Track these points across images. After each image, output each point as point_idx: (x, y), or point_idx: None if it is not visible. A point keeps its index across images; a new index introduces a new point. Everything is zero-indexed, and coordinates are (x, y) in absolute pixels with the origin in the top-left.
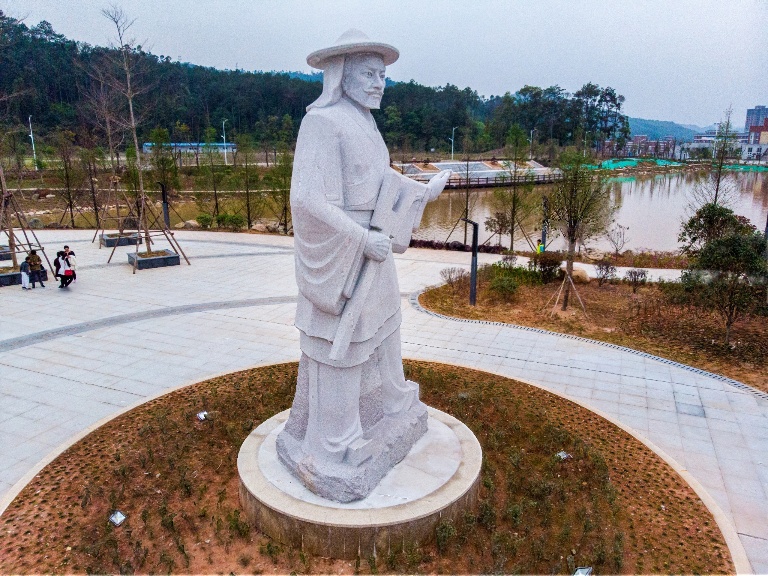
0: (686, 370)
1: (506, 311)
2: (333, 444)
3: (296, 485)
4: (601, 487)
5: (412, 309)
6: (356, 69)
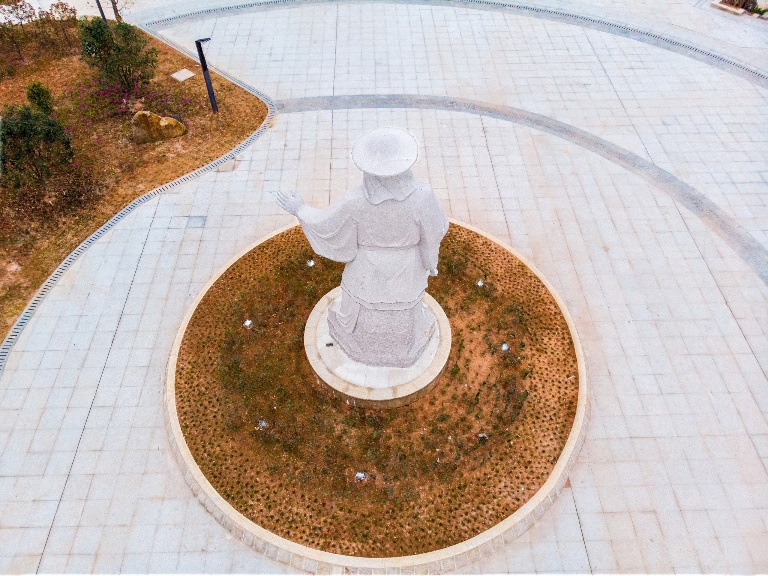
0: (121, 221)
1: None
2: None
3: (432, 344)
4: None
5: None
6: None
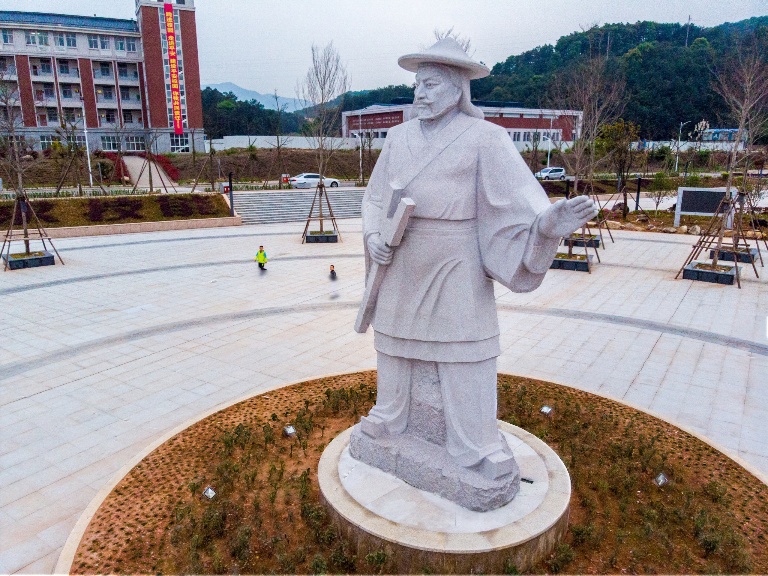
0: None
1: None
2: None
3: None
4: None
5: None
6: None
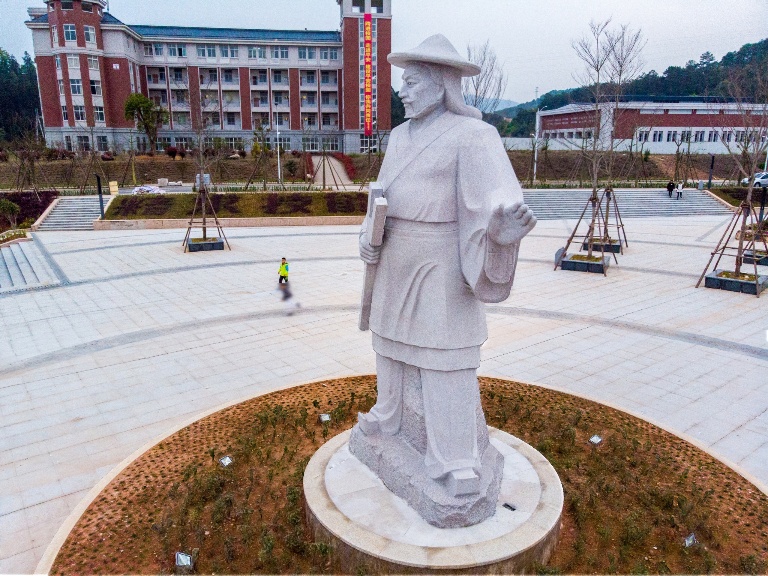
0: None
1: None
2: None
3: None
4: None
5: None
6: None
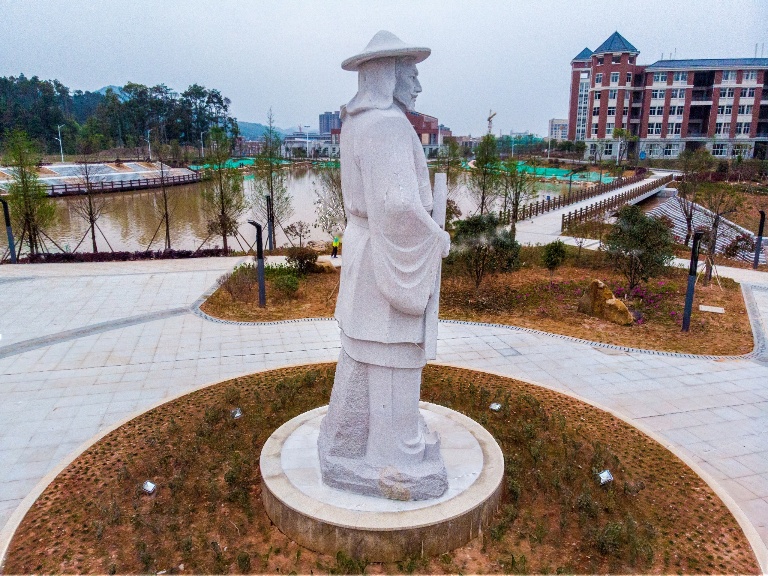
0: (476, 325)
1: (298, 307)
2: (413, 446)
3: (381, 501)
4: (543, 419)
5: (210, 322)
6: (404, 72)
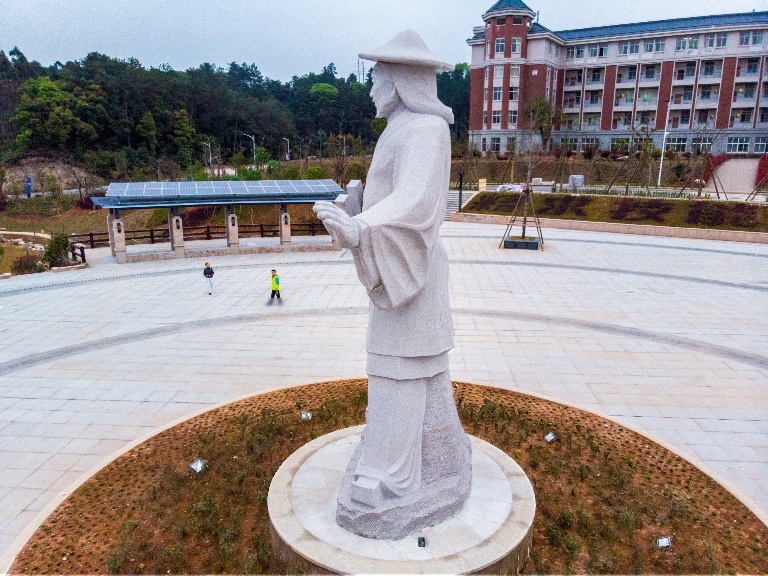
0: None
1: None
2: None
3: None
4: None
5: None
6: None
